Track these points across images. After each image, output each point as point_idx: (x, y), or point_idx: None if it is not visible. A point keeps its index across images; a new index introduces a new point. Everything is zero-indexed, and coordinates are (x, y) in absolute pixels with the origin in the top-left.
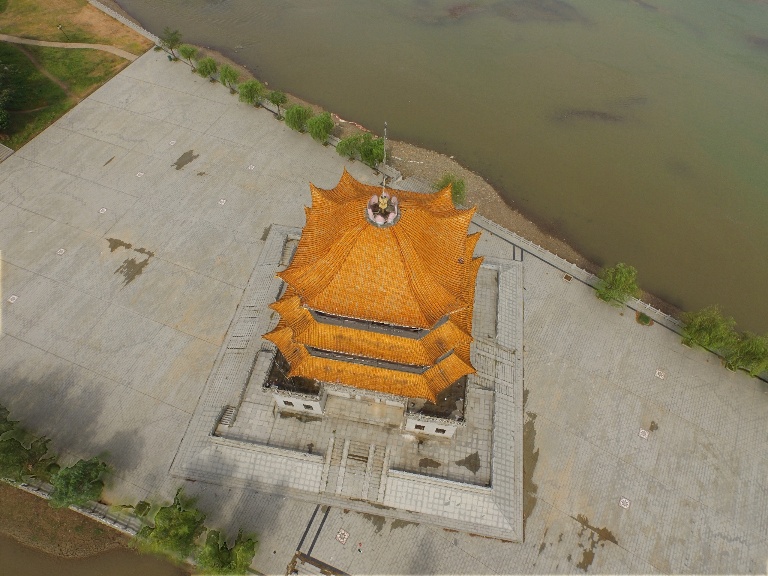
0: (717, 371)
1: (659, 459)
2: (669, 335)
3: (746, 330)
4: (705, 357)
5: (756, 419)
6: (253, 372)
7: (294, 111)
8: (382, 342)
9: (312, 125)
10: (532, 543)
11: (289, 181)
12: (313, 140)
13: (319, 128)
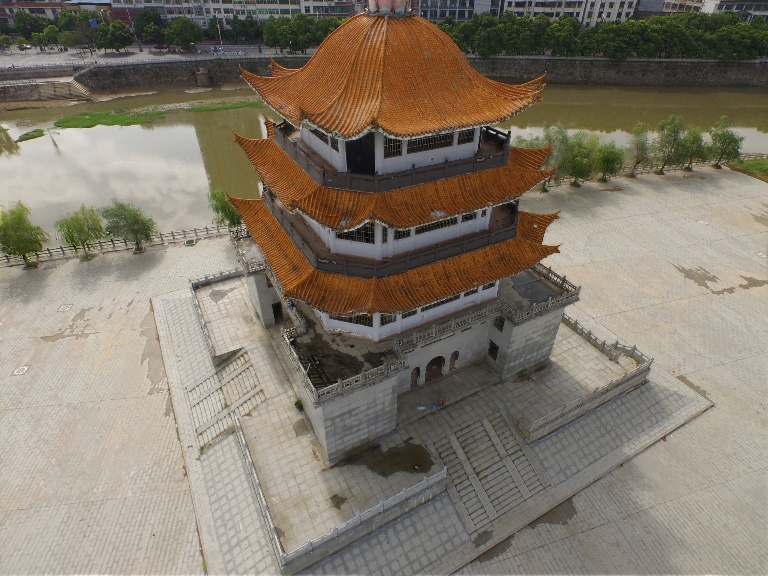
0: None
1: None
2: None
3: None
4: None
5: None
6: None
7: None
8: None
9: None
10: (142, 302)
11: None
12: None
13: None
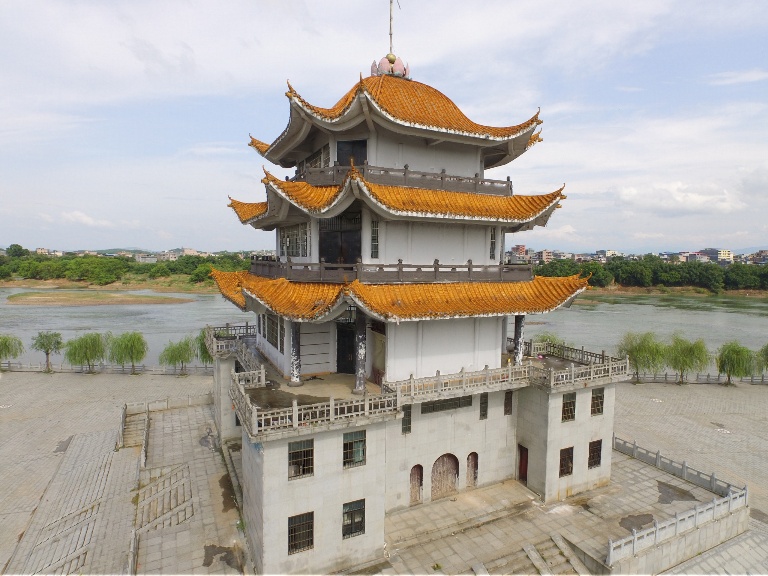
0: (680, 388)
1: (766, 439)
2: (620, 384)
3: (661, 337)
4: (660, 385)
5: (749, 398)
6: (139, 570)
7: (85, 336)
8: (472, 206)
9: (118, 342)
10: None
11: (88, 402)
12: (113, 376)
13: (131, 341)
